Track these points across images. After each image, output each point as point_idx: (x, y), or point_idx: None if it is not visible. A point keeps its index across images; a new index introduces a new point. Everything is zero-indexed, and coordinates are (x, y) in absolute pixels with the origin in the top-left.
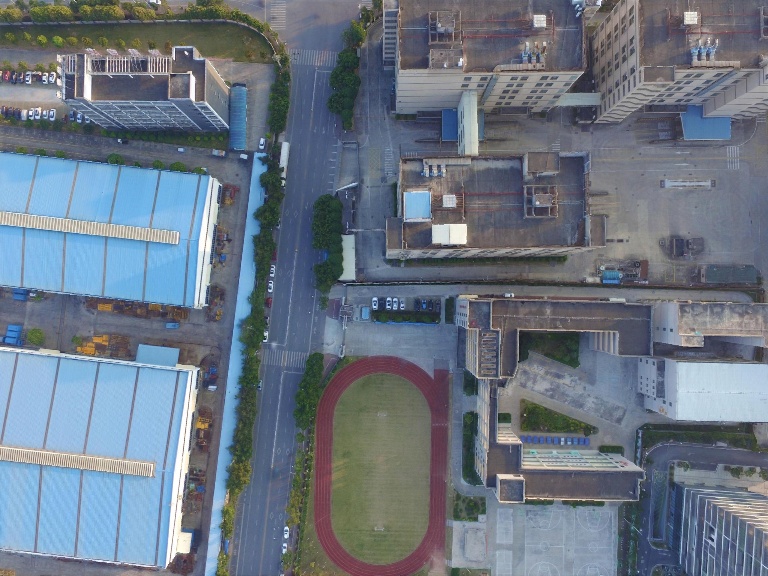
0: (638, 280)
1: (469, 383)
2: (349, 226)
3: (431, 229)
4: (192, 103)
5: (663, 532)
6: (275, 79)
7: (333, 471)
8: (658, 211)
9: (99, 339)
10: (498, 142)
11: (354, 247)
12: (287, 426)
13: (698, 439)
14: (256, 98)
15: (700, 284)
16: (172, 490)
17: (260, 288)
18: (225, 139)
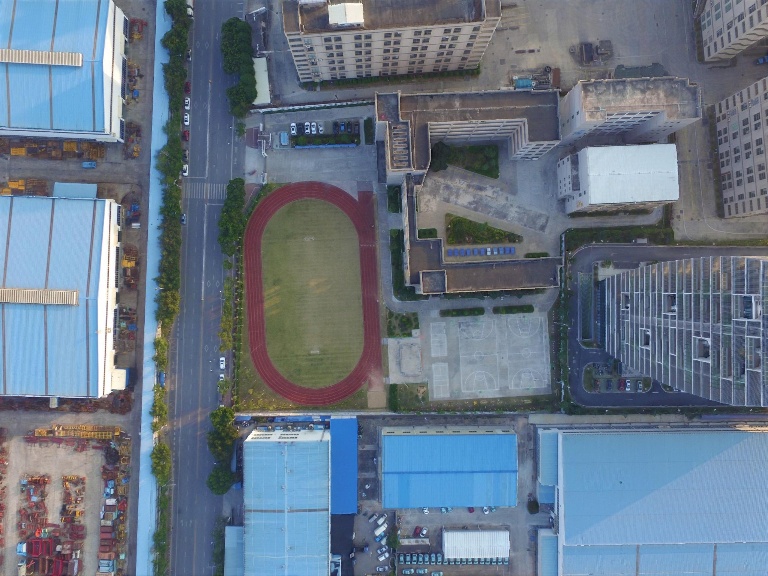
0: (551, 88)
1: (393, 201)
2: (259, 49)
3: (328, 12)
4: None
5: (592, 332)
6: None
7: (265, 299)
8: (566, 20)
9: (15, 184)
10: None
11: (266, 70)
12: (215, 258)
13: (618, 235)
14: None
15: None
16: (97, 317)
17: (174, 117)
18: None
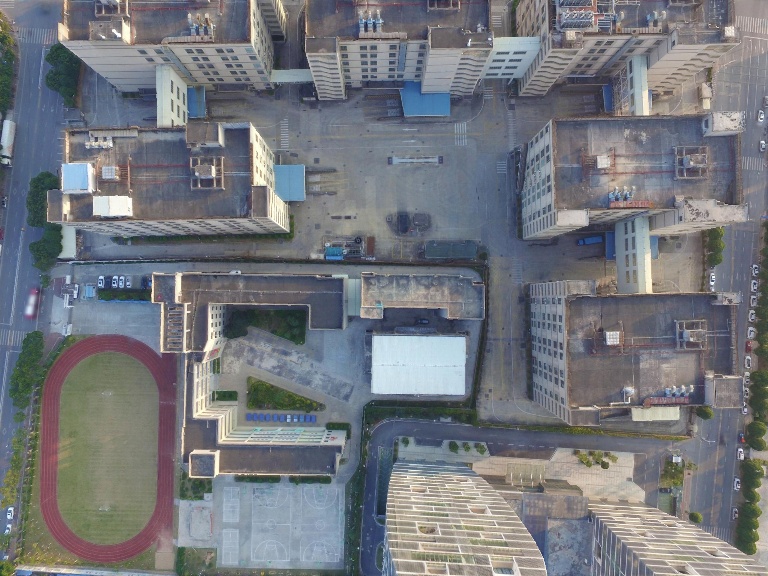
0: (365, 256)
1: None
2: None
3: None
4: None
5: None
6: None
7: (59, 451)
8: (386, 188)
9: None
10: (226, 120)
11: None
12: (13, 406)
13: (417, 414)
14: None
15: (426, 260)
16: None
17: None
18: None
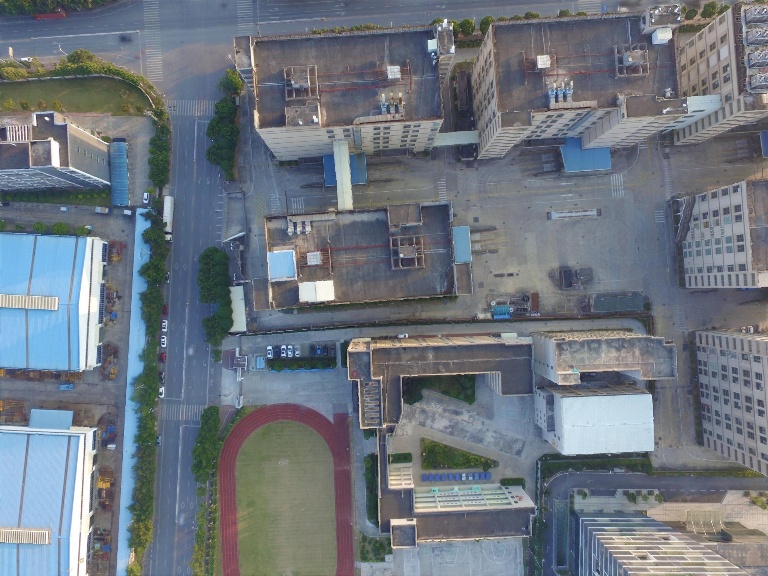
0: (530, 313)
1: None
2: (236, 278)
3: (299, 287)
4: (56, 169)
5: (567, 559)
6: (156, 131)
7: (238, 521)
8: (546, 243)
9: None
10: (384, 183)
11: (243, 298)
12: (189, 480)
13: (594, 467)
14: (137, 152)
15: (591, 313)
16: (69, 556)
17: (150, 345)
18: (108, 195)
